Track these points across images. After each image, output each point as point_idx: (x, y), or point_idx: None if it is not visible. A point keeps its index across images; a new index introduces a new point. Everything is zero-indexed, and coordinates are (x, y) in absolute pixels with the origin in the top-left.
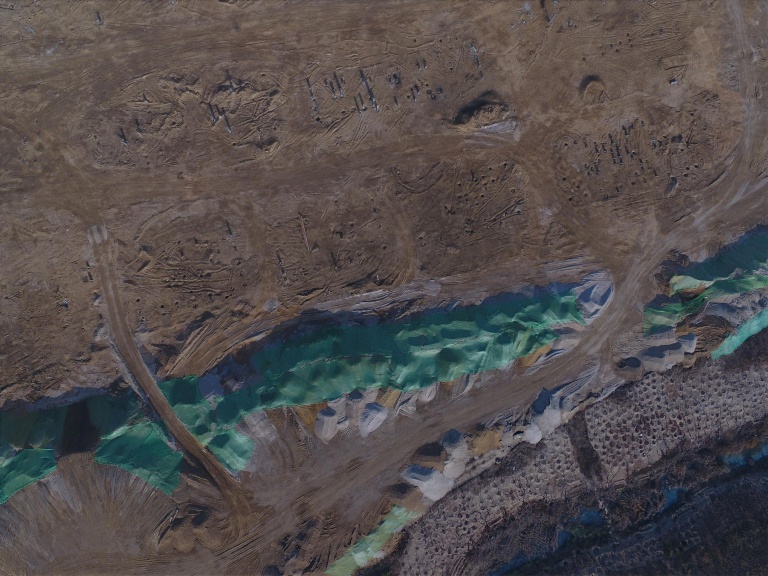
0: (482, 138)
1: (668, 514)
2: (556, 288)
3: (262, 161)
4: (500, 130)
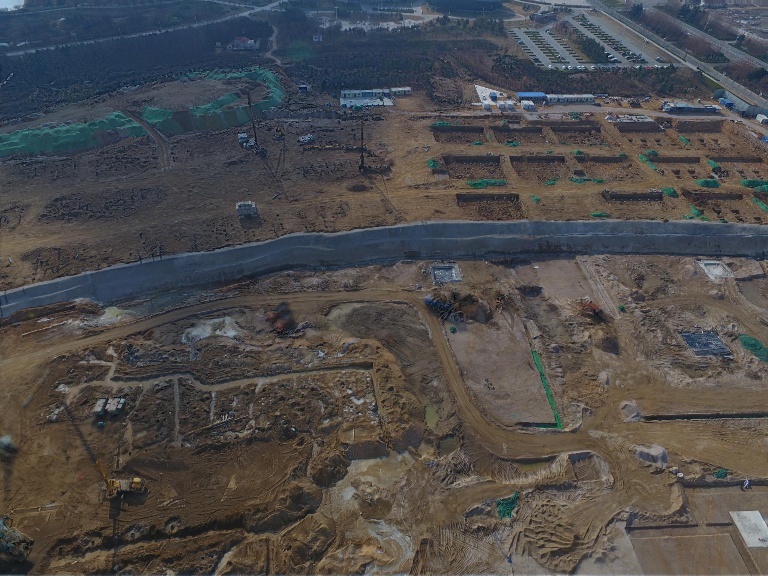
0: None
1: None
2: None
3: None
4: None
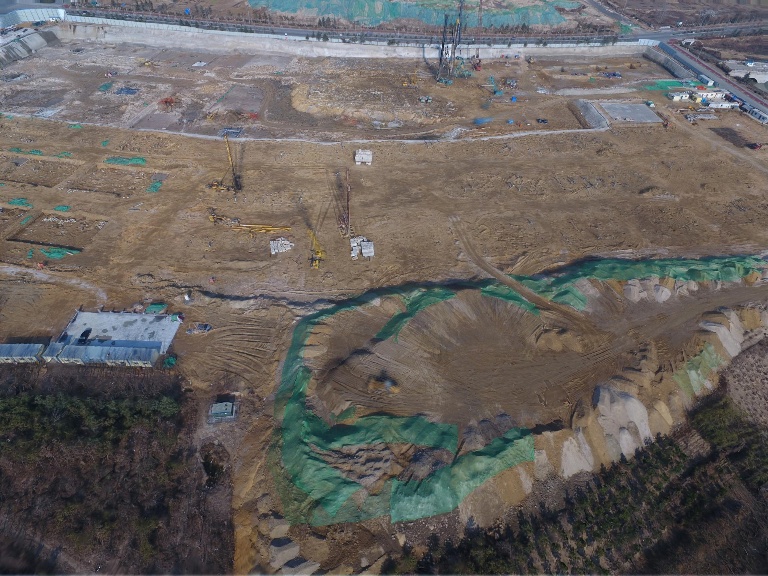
0: (658, 199)
1: None
2: None
3: (539, 200)
4: None
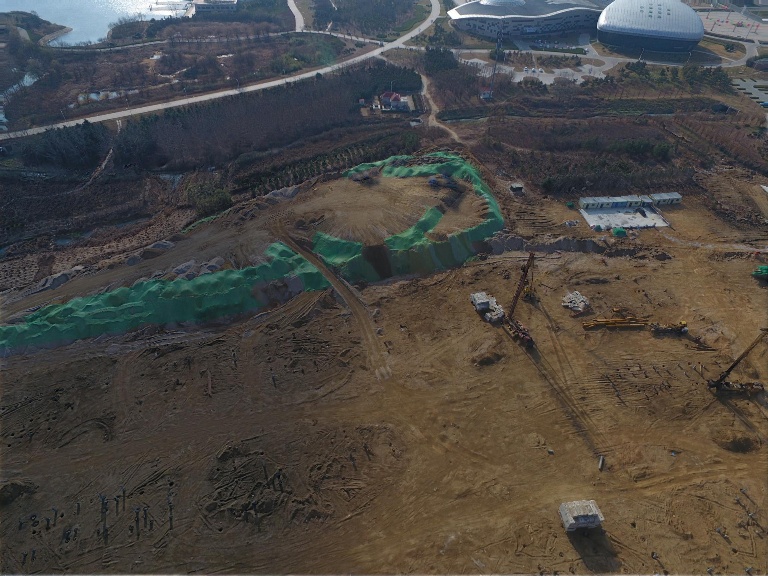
0: (1, 476)
1: (9, 243)
2: (5, 352)
3: (237, 439)
4: None
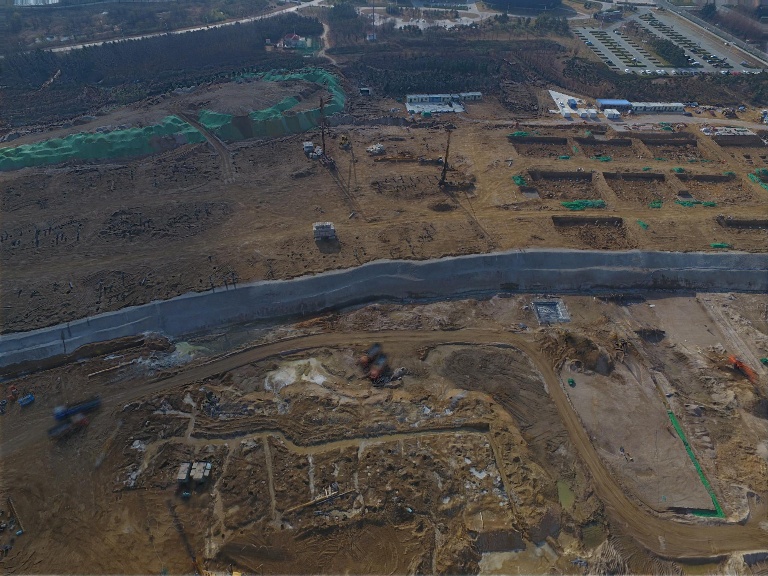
0: None
1: None
2: None
3: (126, 208)
4: None
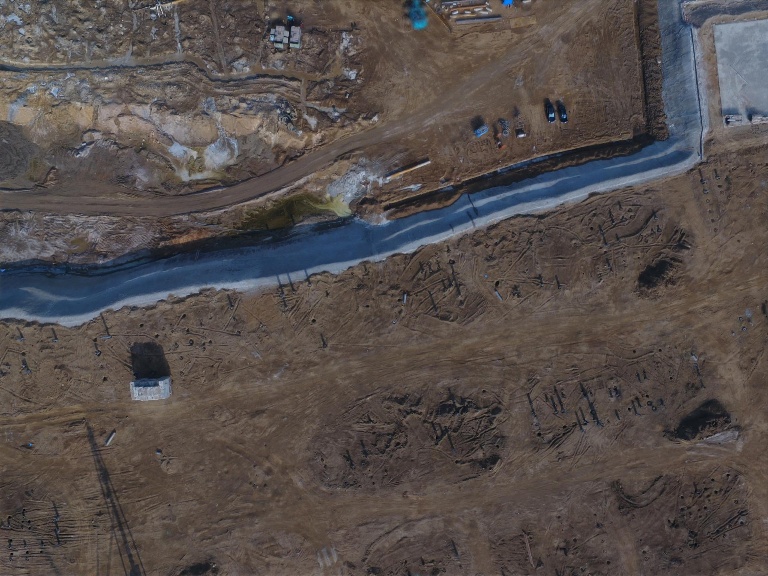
0: (704, 449)
1: None
2: None
3: (485, 478)
4: (722, 440)
